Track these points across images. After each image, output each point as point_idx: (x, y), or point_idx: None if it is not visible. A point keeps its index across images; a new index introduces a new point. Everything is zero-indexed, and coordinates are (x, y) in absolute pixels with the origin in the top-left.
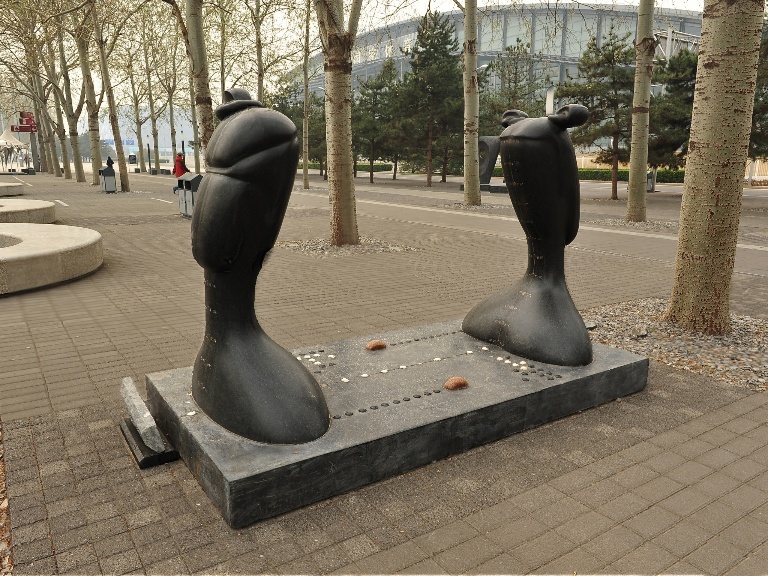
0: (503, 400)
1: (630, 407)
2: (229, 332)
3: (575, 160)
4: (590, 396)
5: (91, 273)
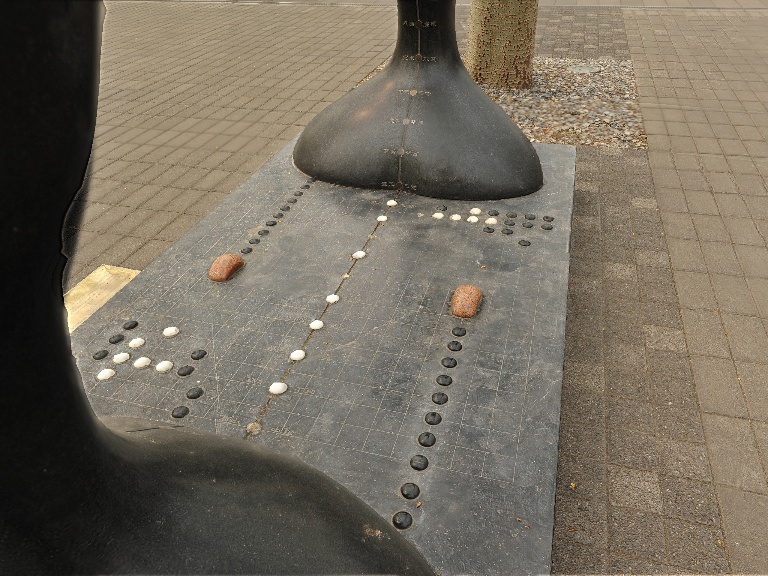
0: (563, 301)
1: (592, 221)
2: (66, 553)
3: None
4: None
5: None
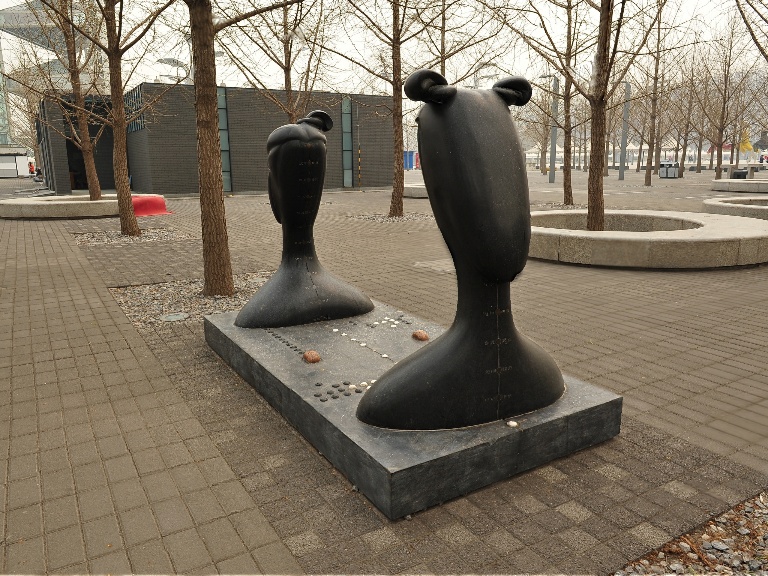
0: (272, 372)
1: (330, 492)
2: None
3: (451, 146)
4: (326, 444)
5: (699, 270)
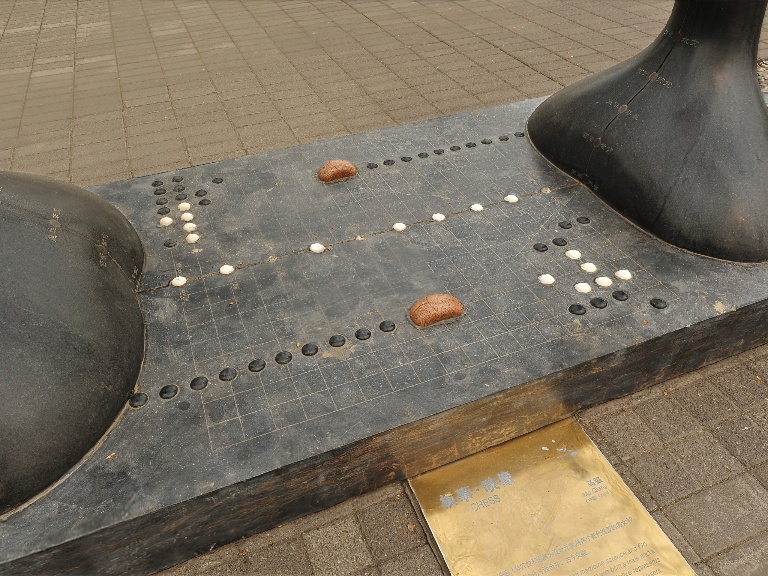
0: (295, 147)
1: None
2: None
3: None
4: None
5: None
